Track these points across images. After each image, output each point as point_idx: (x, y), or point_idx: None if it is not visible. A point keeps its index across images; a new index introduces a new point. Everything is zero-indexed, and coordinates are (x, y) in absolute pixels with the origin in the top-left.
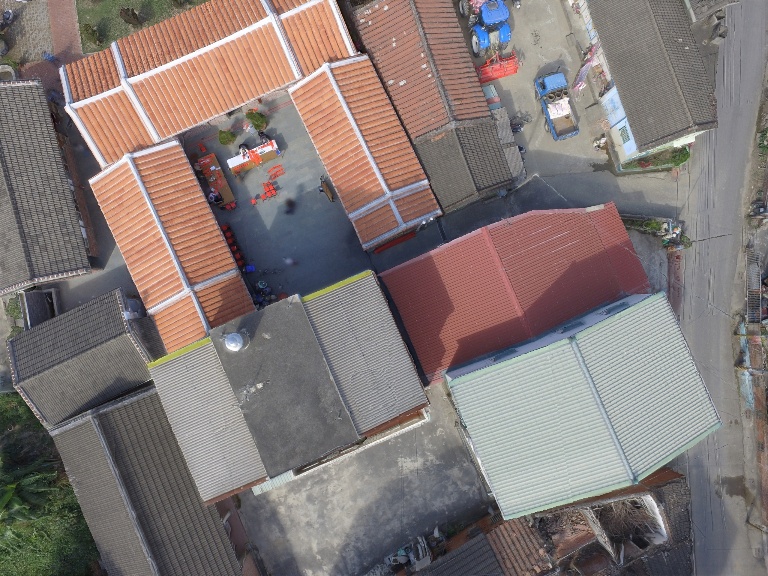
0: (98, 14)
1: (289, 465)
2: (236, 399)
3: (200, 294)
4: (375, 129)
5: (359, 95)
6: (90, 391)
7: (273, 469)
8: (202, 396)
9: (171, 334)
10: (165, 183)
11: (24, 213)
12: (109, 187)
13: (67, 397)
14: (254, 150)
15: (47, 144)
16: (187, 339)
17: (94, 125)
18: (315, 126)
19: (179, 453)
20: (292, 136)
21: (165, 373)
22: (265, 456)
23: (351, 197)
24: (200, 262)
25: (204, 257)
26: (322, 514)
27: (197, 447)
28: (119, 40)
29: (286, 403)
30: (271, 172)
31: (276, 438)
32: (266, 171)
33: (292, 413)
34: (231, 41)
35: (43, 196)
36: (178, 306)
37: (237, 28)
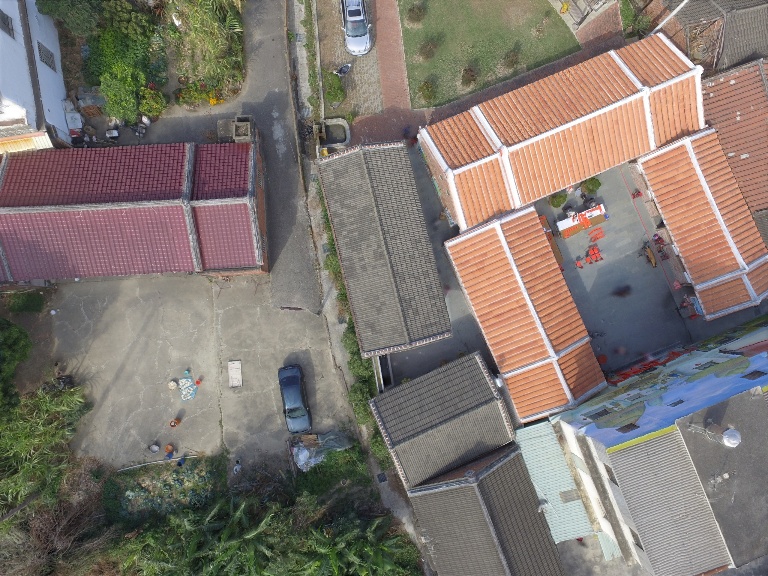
0: (426, 70)
1: (754, 555)
2: (699, 487)
3: (560, 361)
4: (726, 203)
5: (711, 169)
6: (452, 454)
7: (739, 558)
8: (663, 483)
9: (525, 399)
10: (526, 249)
11: (399, 276)
12: (469, 251)
13: (431, 460)
14: (583, 213)
15: (413, 206)
16: (544, 405)
17: (465, 190)
18: (665, 197)
19: (535, 518)
20: (612, 199)
21: (624, 458)
22: (732, 545)
23: (700, 269)
24: (560, 329)
25: (562, 324)
26: (636, 575)
27: (655, 532)
28: (481, 104)
29: (752, 494)
30: (591, 234)
31: (742, 528)
32: (587, 233)
33: (757, 504)
34: (603, 113)
35: (413, 259)
36: (536, 372)
37: (608, 100)
